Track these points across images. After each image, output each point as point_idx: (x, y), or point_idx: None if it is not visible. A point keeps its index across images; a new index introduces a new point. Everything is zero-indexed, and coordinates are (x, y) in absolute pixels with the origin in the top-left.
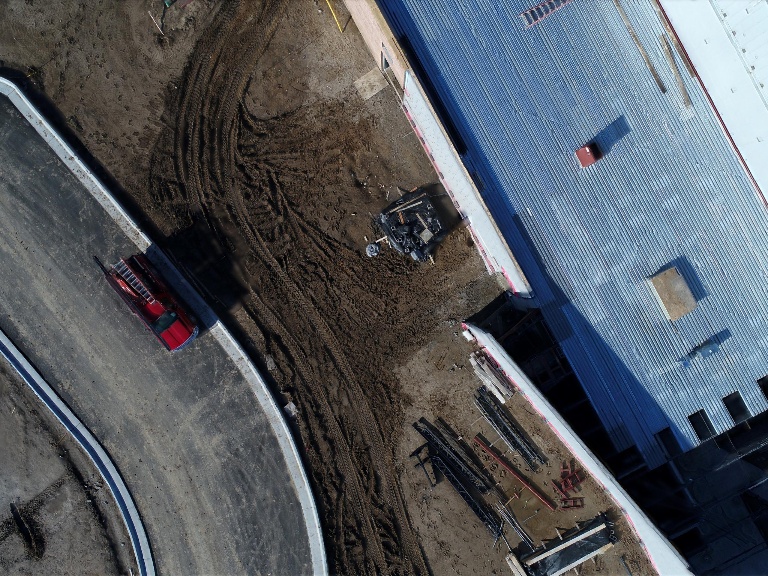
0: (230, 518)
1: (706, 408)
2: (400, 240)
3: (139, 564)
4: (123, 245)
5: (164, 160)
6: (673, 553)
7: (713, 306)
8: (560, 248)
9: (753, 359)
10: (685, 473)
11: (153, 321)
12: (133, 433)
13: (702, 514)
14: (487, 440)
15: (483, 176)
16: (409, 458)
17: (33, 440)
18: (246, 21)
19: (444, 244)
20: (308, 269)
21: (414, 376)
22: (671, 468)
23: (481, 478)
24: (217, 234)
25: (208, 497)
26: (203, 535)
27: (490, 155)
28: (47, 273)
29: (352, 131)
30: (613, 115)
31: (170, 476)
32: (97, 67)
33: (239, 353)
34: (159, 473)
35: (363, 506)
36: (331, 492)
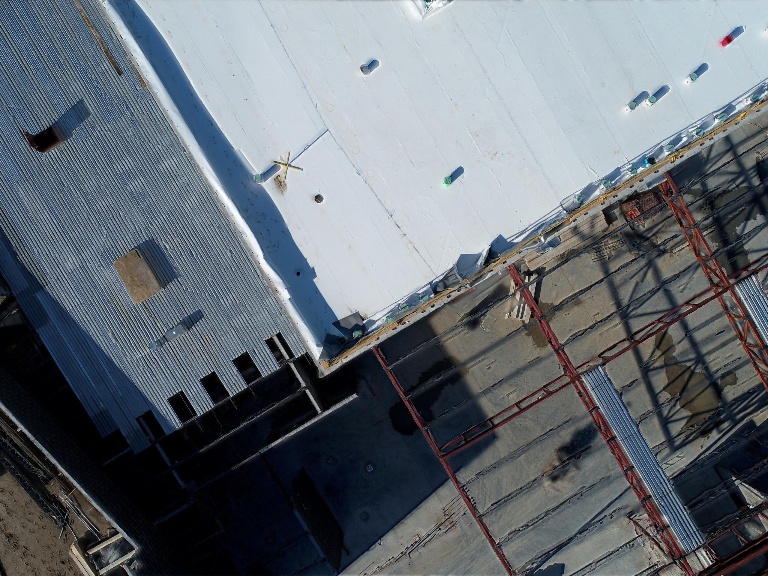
0: None
1: (185, 390)
2: None
3: None
4: None
5: None
6: None
7: (184, 287)
8: (30, 235)
9: (227, 339)
10: (170, 455)
11: None
12: None
13: (189, 496)
14: None
15: None
16: None
17: None
18: None
19: None
20: None
21: None
22: (158, 451)
23: (42, 469)
24: None
25: None
26: None
27: None
28: None
29: None
30: (73, 99)
31: None
32: None
33: None
34: None
35: None
36: None
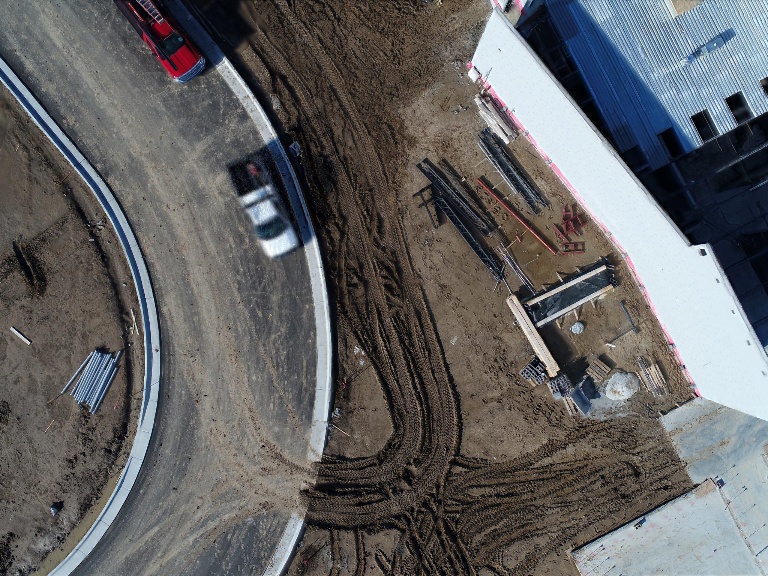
0: (233, 258)
1: (709, 108)
2: None
3: (141, 302)
4: None
5: None
6: (675, 231)
7: (718, 5)
8: None
9: (757, 59)
10: (687, 175)
11: (160, 41)
12: (137, 171)
13: (703, 215)
14: (490, 183)
15: None
16: (412, 200)
17: (37, 178)
18: None
19: None
20: (316, 8)
21: (419, 117)
22: (673, 170)
23: (484, 220)
24: None
25: (211, 237)
26: (205, 275)
27: None
28: (54, 8)
29: None
30: None
31: (173, 215)
32: None
33: (245, 91)
34: (163, 212)
35: (365, 248)
36: (334, 233)
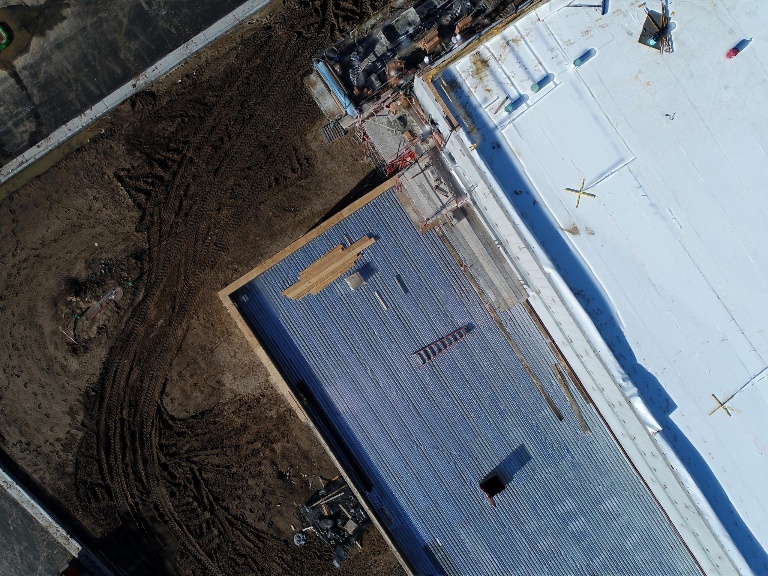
0: None
1: None
2: (325, 533)
3: None
4: (55, 550)
5: (88, 463)
6: None
7: None
8: (472, 575)
9: None
10: None
11: None
12: None
13: None
14: None
15: (390, 510)
16: None
17: None
18: (157, 324)
19: (370, 528)
20: (238, 561)
21: None
22: None
23: None
24: (146, 532)
25: None
26: None
27: (396, 490)
28: None
29: (270, 425)
30: (513, 444)
31: None
32: (15, 377)
33: None
34: None
35: None
36: None
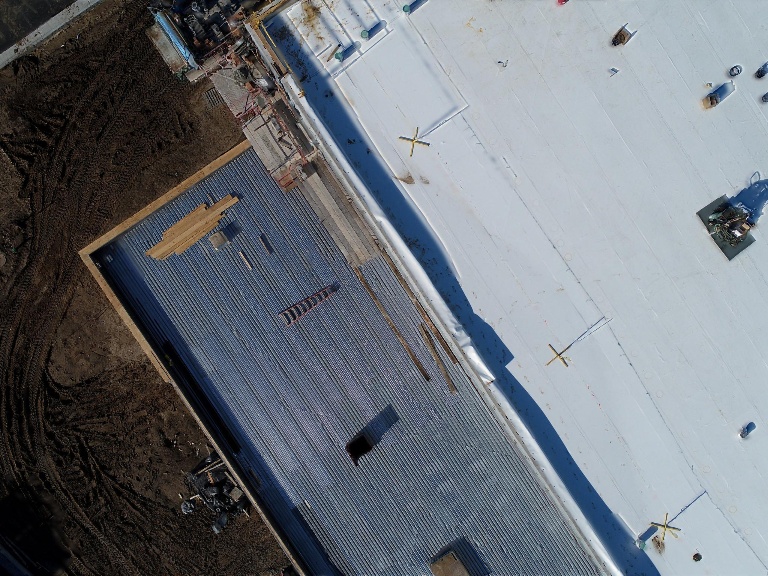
0: None
1: None
2: (210, 500)
3: None
4: None
5: None
6: None
7: None
8: (341, 537)
9: None
10: None
11: None
12: None
13: None
14: None
15: (259, 472)
16: None
17: None
18: (42, 291)
19: None
20: (126, 530)
21: None
22: None
23: None
24: (33, 502)
25: None
26: None
27: (263, 452)
28: None
29: (156, 392)
30: (380, 404)
31: None
32: None
33: None
34: None
35: None
36: None
